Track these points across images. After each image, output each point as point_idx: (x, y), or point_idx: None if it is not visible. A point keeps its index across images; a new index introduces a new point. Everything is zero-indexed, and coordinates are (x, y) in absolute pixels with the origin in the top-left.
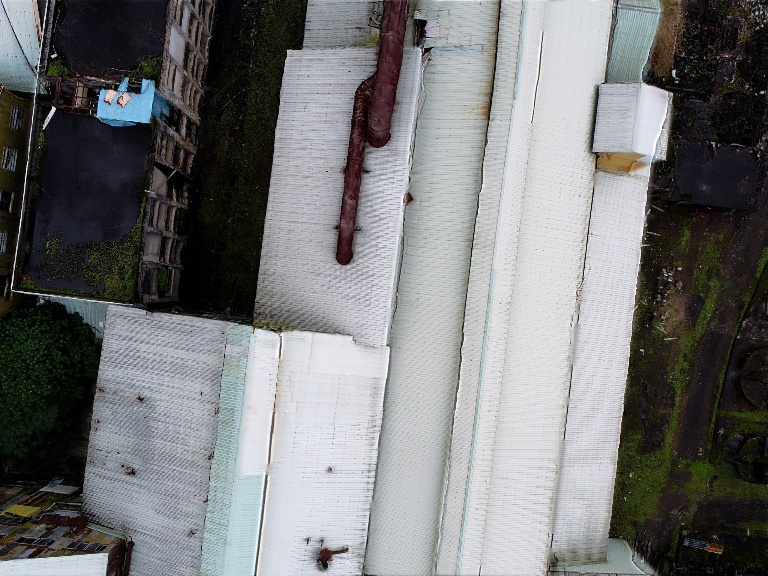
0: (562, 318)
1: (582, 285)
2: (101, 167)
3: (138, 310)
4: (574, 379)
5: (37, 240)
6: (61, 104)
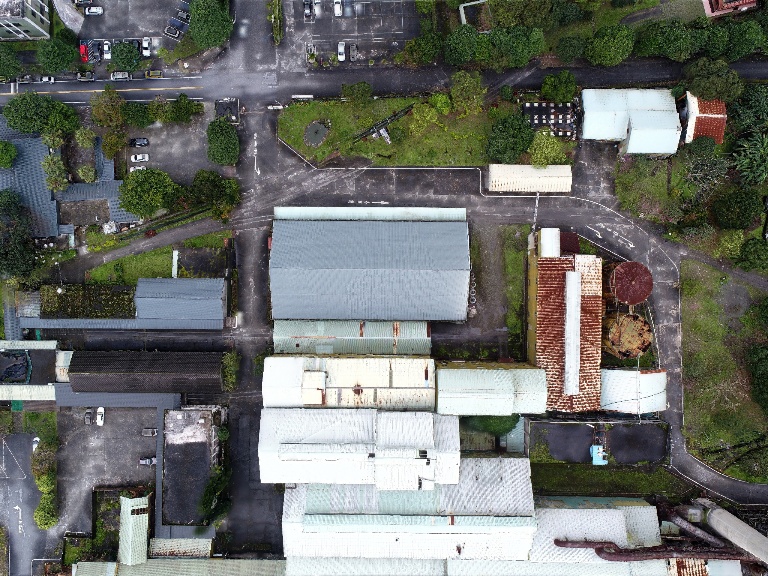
0: None
1: None
2: (575, 445)
3: None
4: None
5: (547, 426)
6: None
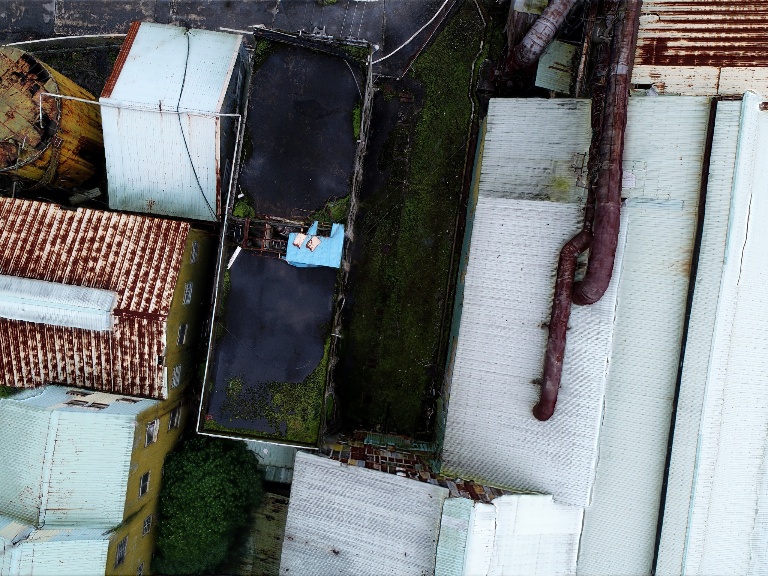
0: (752, 471)
1: None
2: (285, 307)
3: (332, 461)
4: None
5: (220, 380)
6: (250, 247)
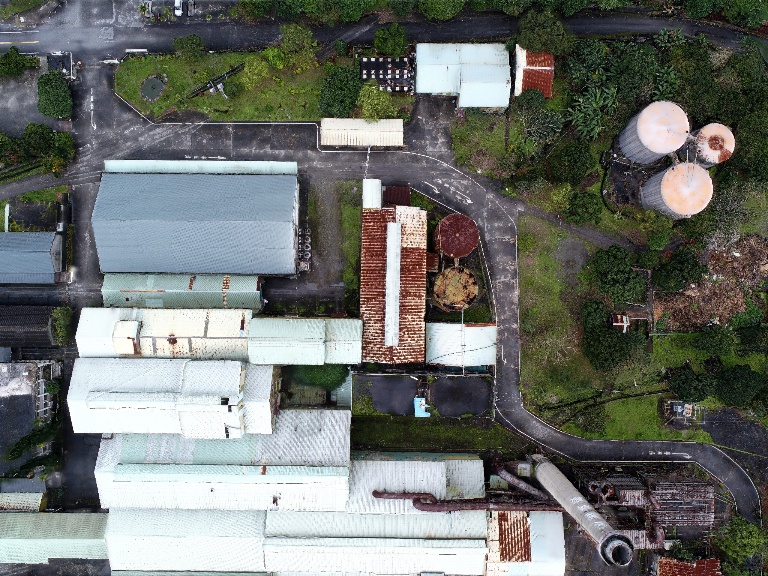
0: (362, 569)
1: (375, 574)
2: (399, 398)
3: None
4: (341, 573)
5: (371, 378)
6: None
